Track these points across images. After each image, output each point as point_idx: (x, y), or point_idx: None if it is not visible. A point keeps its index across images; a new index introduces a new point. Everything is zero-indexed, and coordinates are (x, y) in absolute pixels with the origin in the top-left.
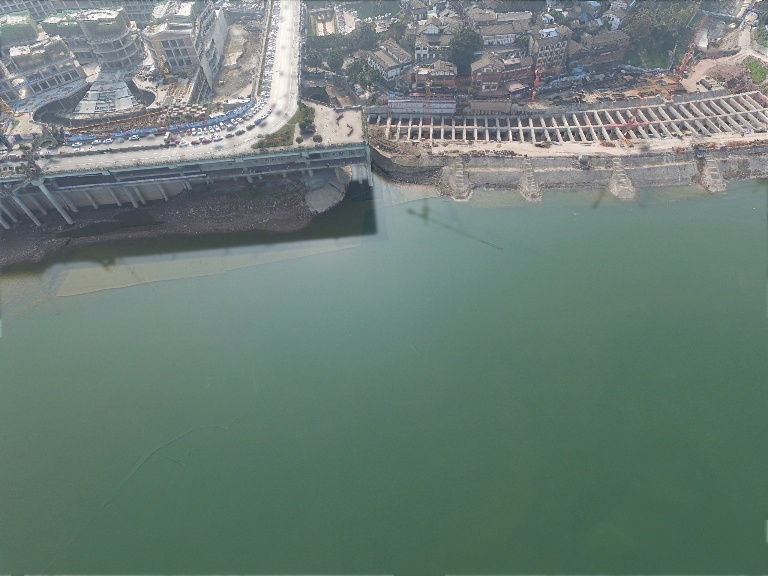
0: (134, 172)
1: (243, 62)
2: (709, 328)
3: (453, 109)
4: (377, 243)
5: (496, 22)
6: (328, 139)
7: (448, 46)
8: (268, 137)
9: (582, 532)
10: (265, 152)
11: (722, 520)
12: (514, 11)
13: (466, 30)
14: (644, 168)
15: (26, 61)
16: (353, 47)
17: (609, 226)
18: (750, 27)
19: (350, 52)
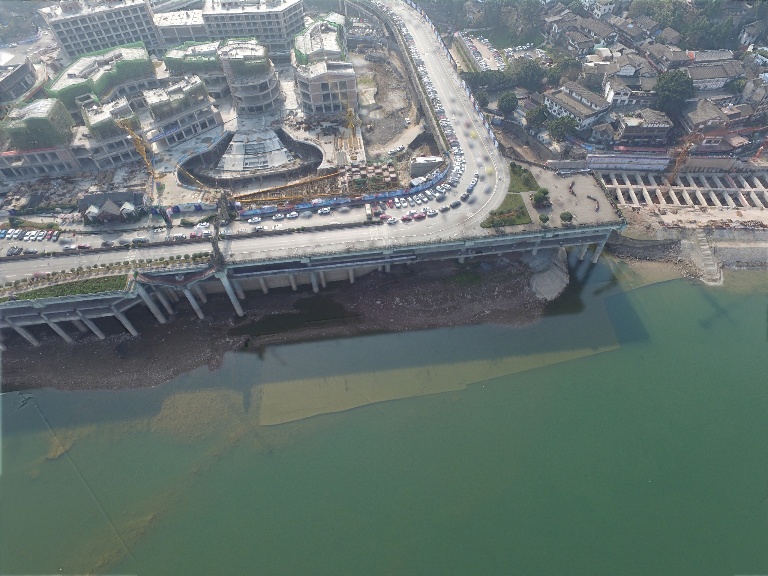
0: (334, 257)
1: (382, 100)
2: None
3: (664, 165)
4: (640, 344)
5: (693, 62)
6: (573, 215)
7: (653, 91)
8: (502, 213)
9: None
10: (504, 234)
11: None
12: (702, 48)
13: (680, 74)
14: None
15: (164, 109)
16: (509, 84)
17: None
18: None
19: (506, 90)
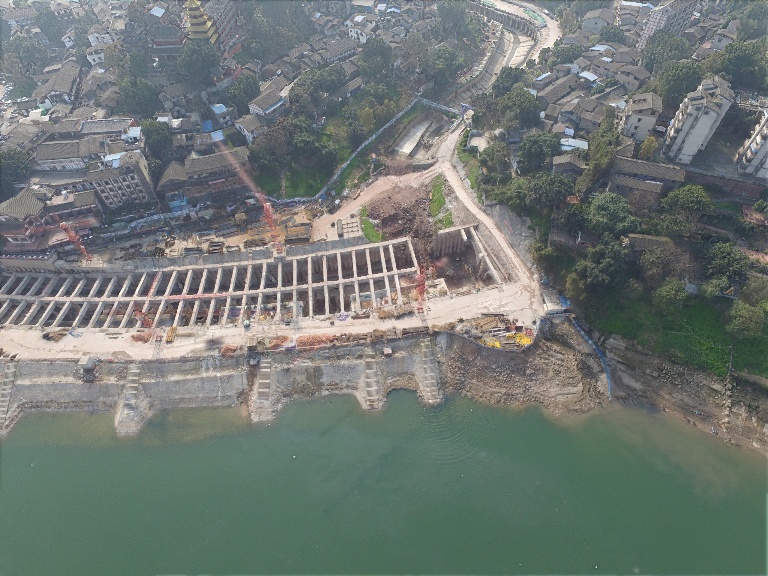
0: None
1: None
2: None
3: None
4: None
5: (82, 133)
6: None
7: None
8: None
9: None
10: None
11: None
12: (129, 112)
13: None
14: (169, 381)
15: None
16: None
17: (59, 494)
18: (463, 128)
19: None
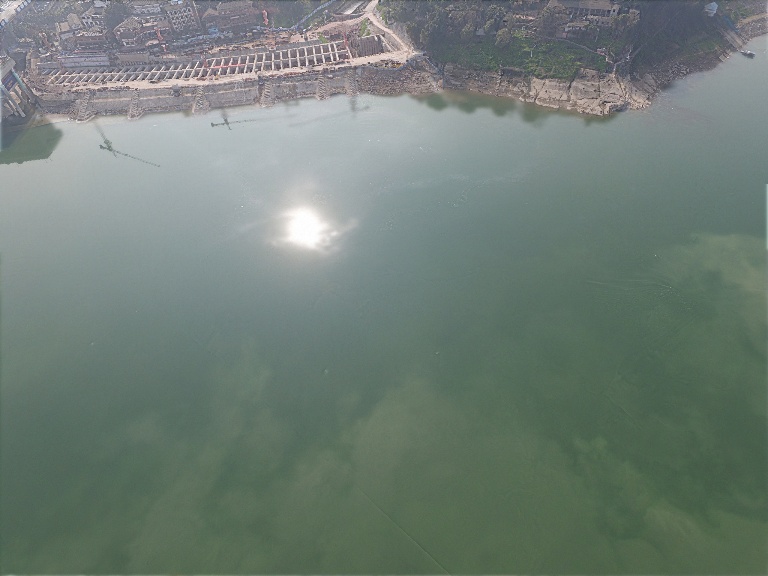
0: None
1: None
2: (180, 183)
3: (107, 61)
4: None
5: None
6: None
7: None
8: None
9: (1, 286)
10: None
11: (92, 274)
12: None
13: (113, 1)
14: (219, 93)
15: None
16: None
17: (170, 131)
18: None
19: None
